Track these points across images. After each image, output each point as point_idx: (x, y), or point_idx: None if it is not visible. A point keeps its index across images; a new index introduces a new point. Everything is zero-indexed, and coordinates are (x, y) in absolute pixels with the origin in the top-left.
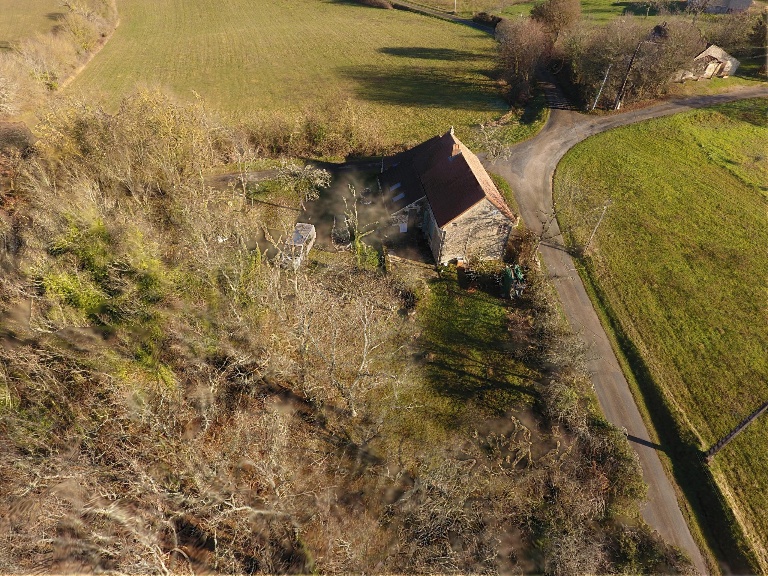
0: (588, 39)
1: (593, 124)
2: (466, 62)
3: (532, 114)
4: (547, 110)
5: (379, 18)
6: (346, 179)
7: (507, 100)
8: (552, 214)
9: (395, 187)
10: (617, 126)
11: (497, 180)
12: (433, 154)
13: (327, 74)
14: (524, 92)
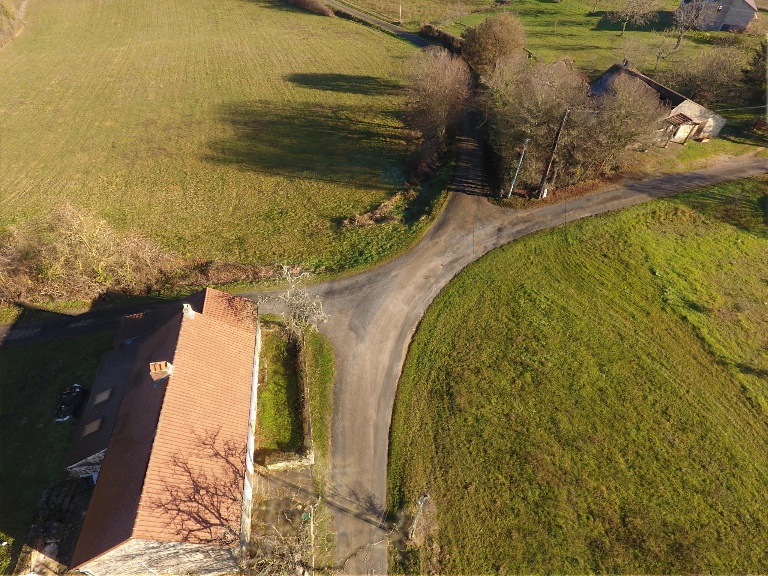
0: (517, 85)
1: (502, 226)
2: (385, 97)
3: (425, 200)
4: (446, 195)
5: (313, 29)
6: (61, 355)
7: (405, 169)
8: (385, 428)
9: (102, 397)
10: (536, 231)
11: (318, 347)
12: (153, 352)
13: (204, 114)
14: (426, 160)
